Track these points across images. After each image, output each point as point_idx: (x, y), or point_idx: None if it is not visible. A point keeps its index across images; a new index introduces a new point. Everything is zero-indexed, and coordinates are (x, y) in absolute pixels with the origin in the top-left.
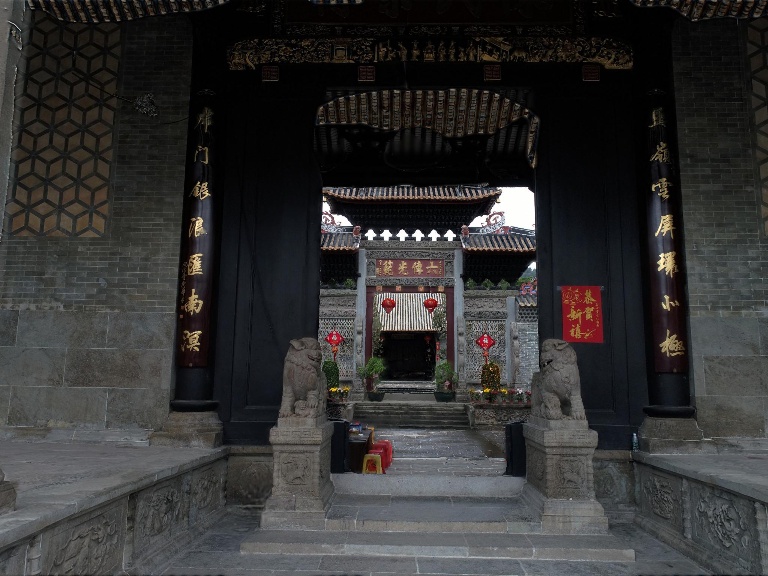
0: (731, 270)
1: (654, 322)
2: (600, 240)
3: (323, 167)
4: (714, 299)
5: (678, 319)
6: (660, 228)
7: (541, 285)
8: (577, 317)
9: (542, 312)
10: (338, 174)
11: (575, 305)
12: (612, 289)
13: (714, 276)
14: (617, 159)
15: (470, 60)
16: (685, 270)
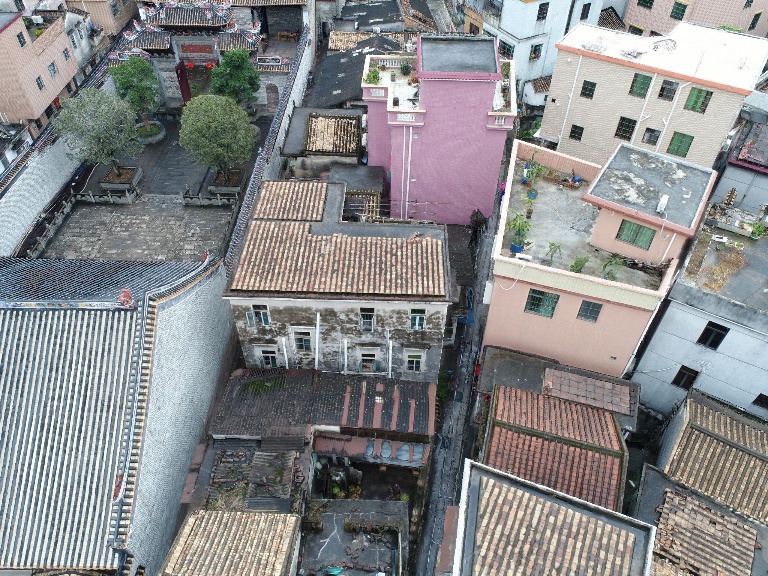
0: None
1: None
2: None
3: (244, 2)
4: None
5: None
6: None
7: None
8: None
9: None
10: None
11: None
12: None
13: None
14: None
15: None
16: None
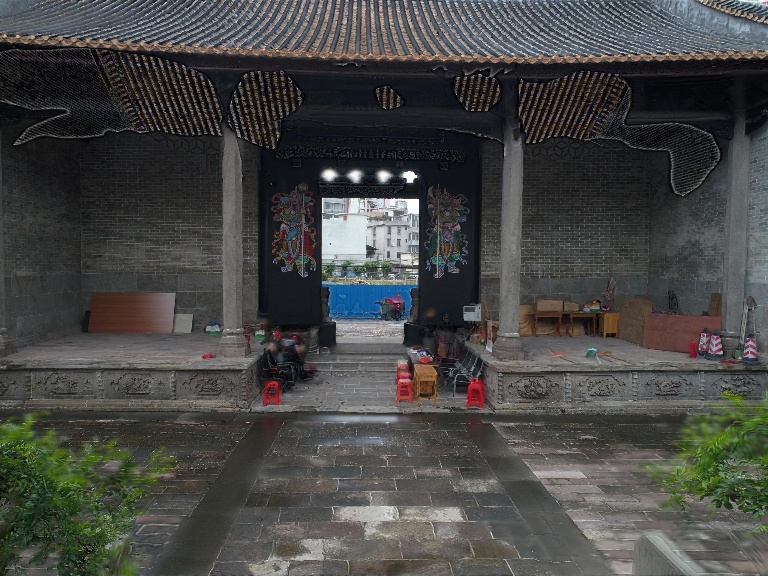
0: None
1: None
2: None
3: None
4: None
5: None
6: None
7: None
8: None
9: None
10: None
11: None
12: None
13: None
14: None
15: (352, 157)
16: None
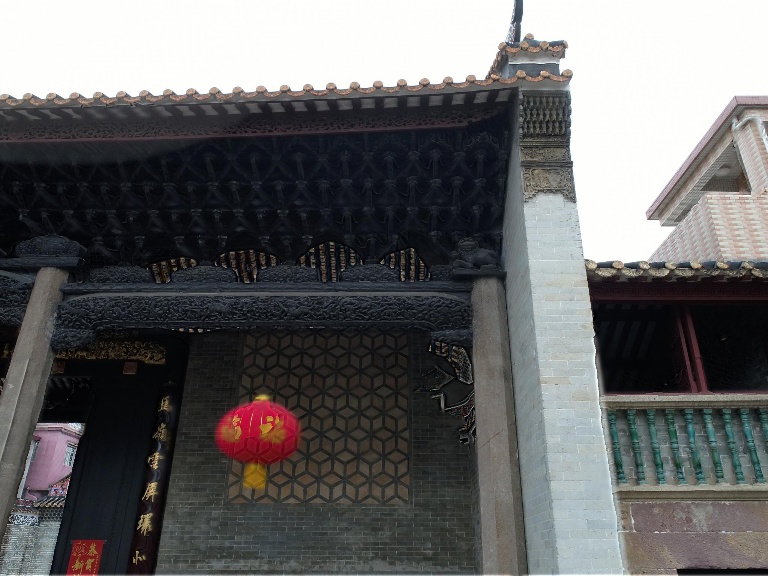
0: (196, 528)
1: (127, 574)
2: (113, 500)
3: None
4: (178, 554)
5: (148, 571)
6: (146, 493)
7: (58, 539)
8: (80, 567)
9: (53, 563)
10: (54, 413)
11: (80, 557)
12: (112, 543)
13: (182, 534)
14: (140, 434)
15: None
16: (161, 528)
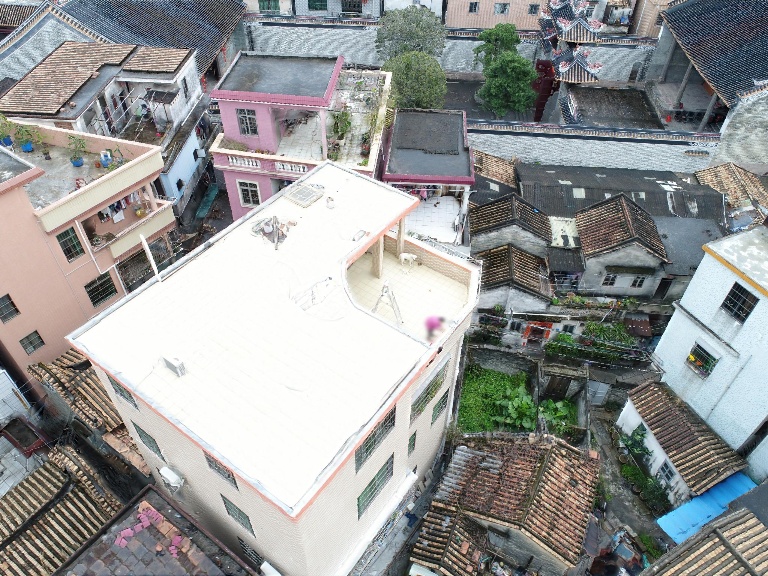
0: None
1: None
2: None
3: None
4: None
5: None
6: None
7: None
8: None
9: None
10: None
11: None
12: None
13: None
14: None
15: None
16: None
